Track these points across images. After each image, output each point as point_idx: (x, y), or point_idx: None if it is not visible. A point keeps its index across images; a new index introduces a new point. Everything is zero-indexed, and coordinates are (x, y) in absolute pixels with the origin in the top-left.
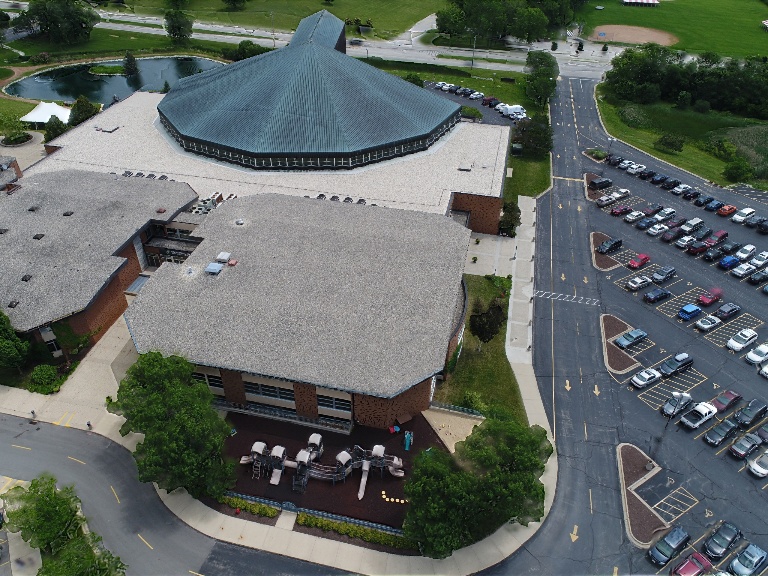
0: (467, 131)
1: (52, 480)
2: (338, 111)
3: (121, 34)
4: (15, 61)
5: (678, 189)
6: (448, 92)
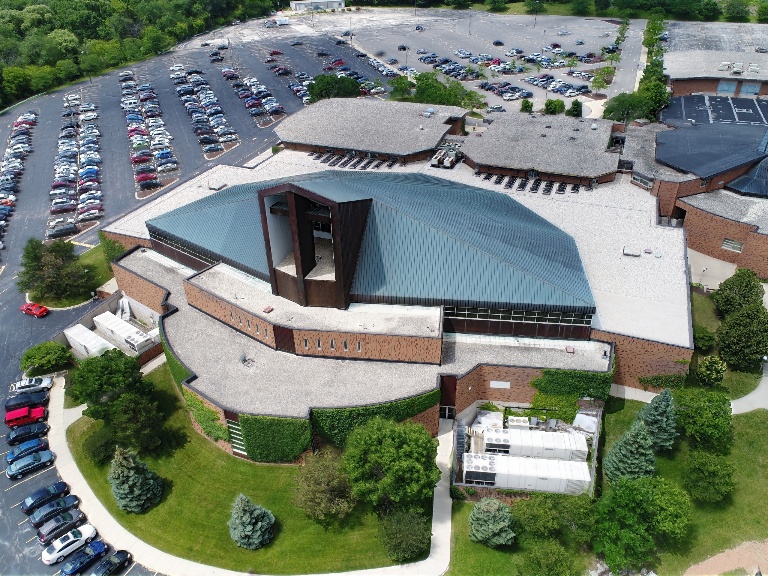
0: None
1: (469, 91)
2: None
3: None
4: None
5: (2, 221)
6: None
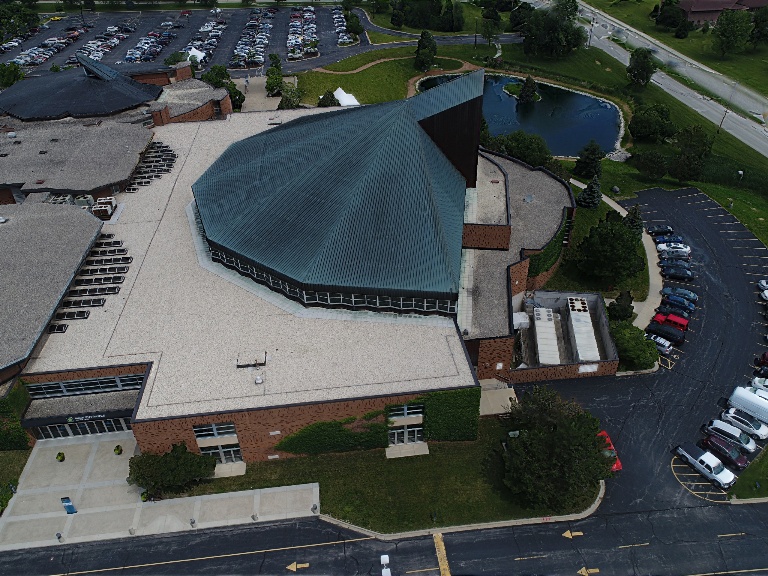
0: (413, 333)
1: None
2: (280, 190)
3: (606, 62)
4: (479, 59)
5: None
6: (761, 304)
